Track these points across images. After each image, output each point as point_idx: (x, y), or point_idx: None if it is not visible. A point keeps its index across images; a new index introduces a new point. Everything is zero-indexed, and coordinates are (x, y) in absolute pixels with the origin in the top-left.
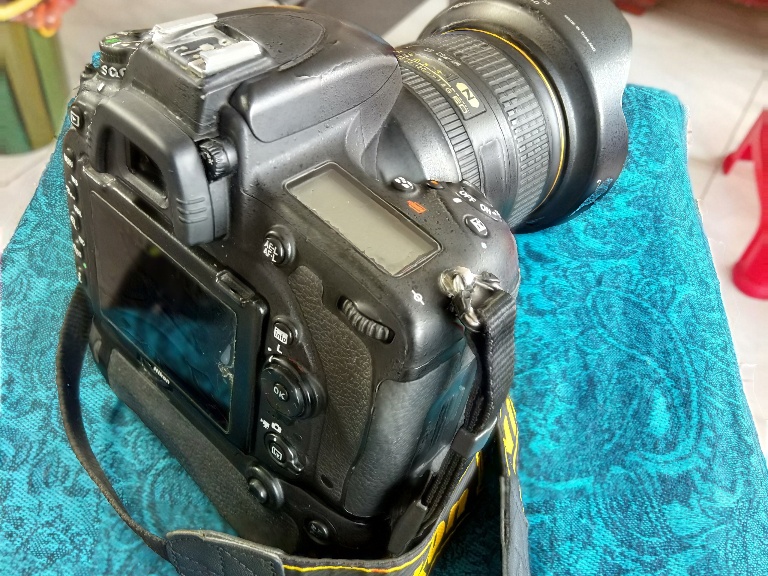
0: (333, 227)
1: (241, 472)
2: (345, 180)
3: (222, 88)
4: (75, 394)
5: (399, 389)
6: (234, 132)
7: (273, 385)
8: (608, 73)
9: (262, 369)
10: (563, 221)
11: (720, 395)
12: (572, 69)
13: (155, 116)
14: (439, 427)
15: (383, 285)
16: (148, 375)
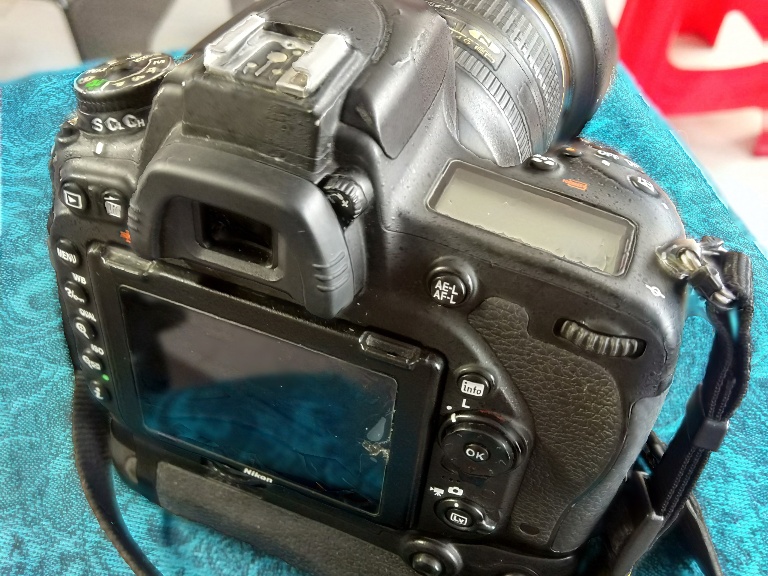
0: (513, 239)
1: (389, 550)
2: (481, 177)
3: (333, 104)
4: (124, 531)
5: (655, 404)
6: (362, 157)
7: (462, 447)
8: None
9: (438, 433)
10: None
11: (763, 281)
12: None
13: (245, 165)
14: None
15: (615, 290)
16: (229, 479)
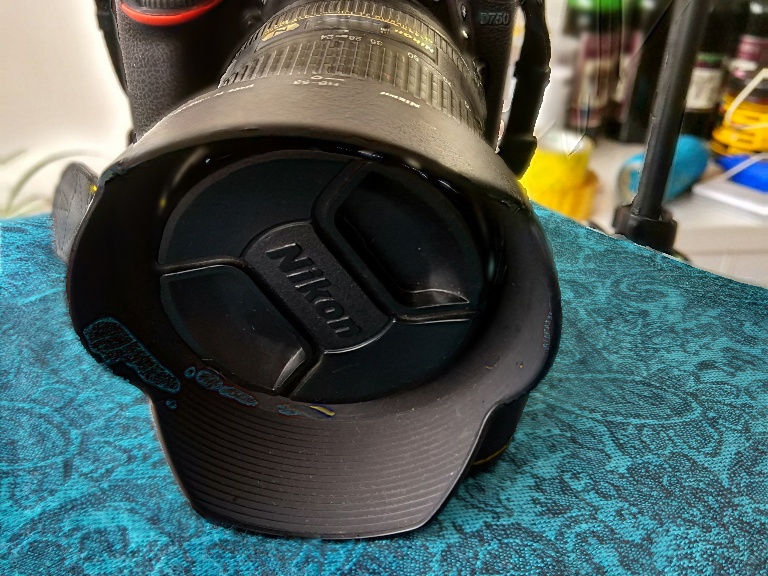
0: None
1: None
2: None
3: None
4: None
5: None
6: None
7: None
8: None
9: None
10: None
11: None
12: None
13: None
14: None
15: None
16: None
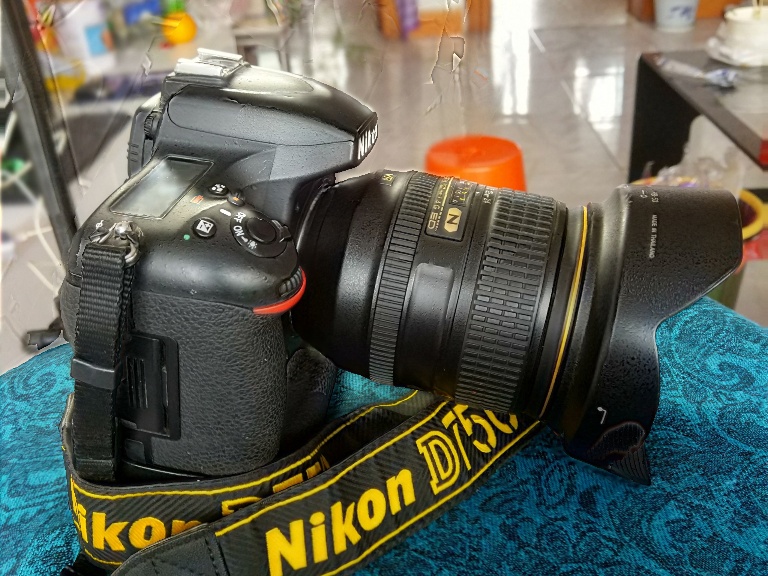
0: (143, 181)
1: None
2: None
3: (175, 82)
4: None
5: None
6: None
7: None
8: (654, 287)
9: None
10: (600, 461)
11: None
12: (611, 263)
13: None
14: (137, 387)
15: None
16: None
